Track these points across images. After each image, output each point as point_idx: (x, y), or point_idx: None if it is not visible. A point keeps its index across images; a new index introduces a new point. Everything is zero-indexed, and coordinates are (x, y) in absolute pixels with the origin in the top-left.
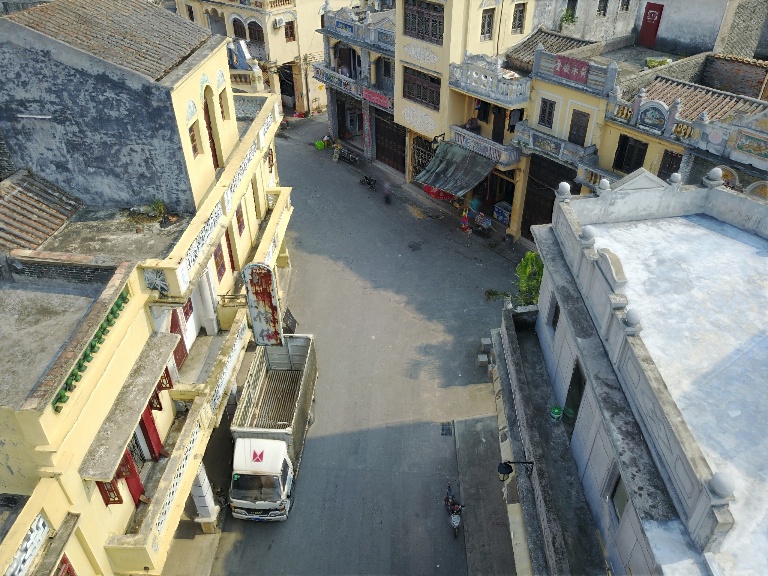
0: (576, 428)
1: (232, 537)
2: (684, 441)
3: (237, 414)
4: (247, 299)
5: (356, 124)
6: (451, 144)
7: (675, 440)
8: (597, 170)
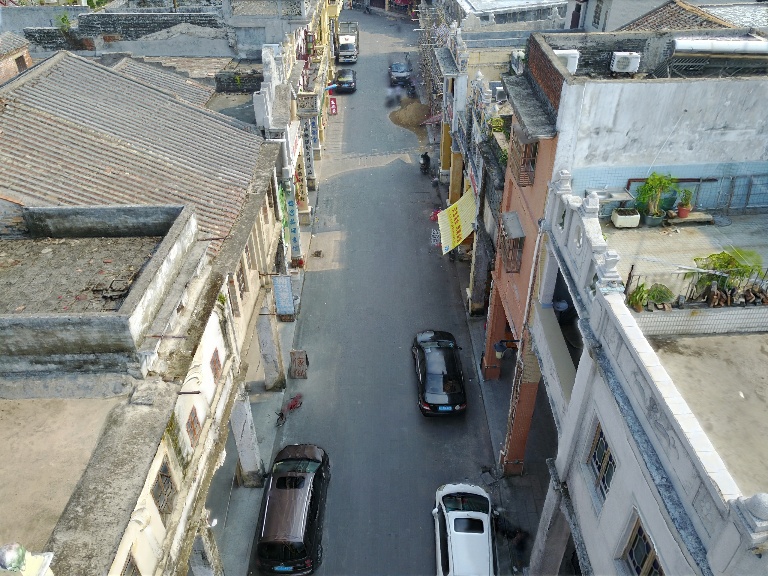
0: None
1: None
2: None
3: None
4: None
5: None
6: None
7: None
8: None
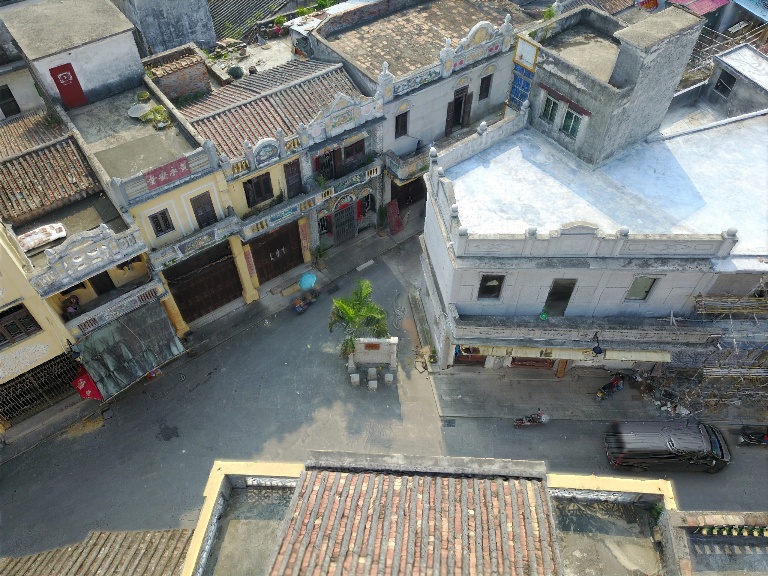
0: (571, 305)
1: None
2: (700, 238)
3: None
4: None
5: None
6: (85, 338)
7: (692, 242)
8: (263, 218)
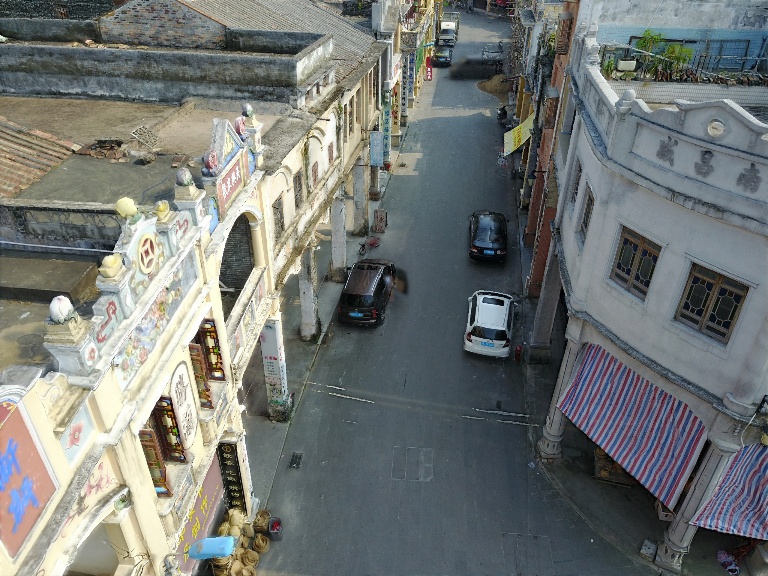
0: None
1: None
2: None
3: None
4: None
5: None
6: None
7: None
8: None
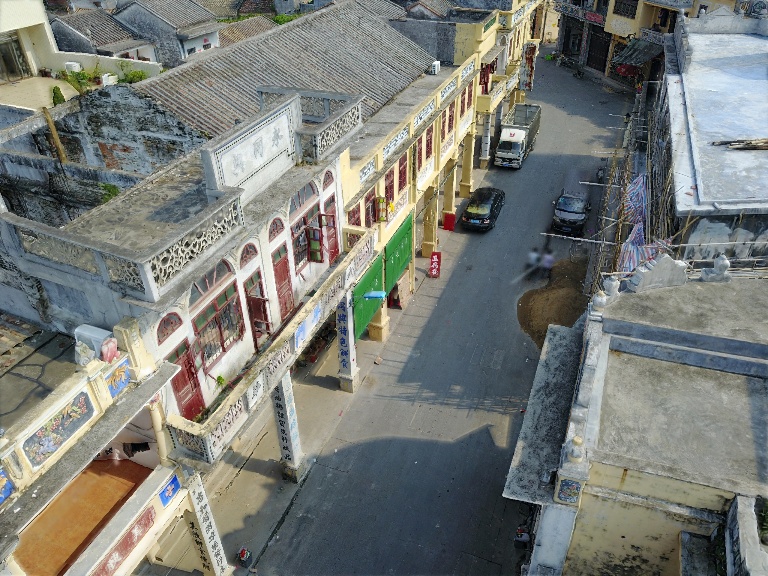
0: None
1: (493, 172)
2: None
3: (503, 122)
4: (521, 62)
5: (576, 46)
6: (639, 40)
7: None
8: None
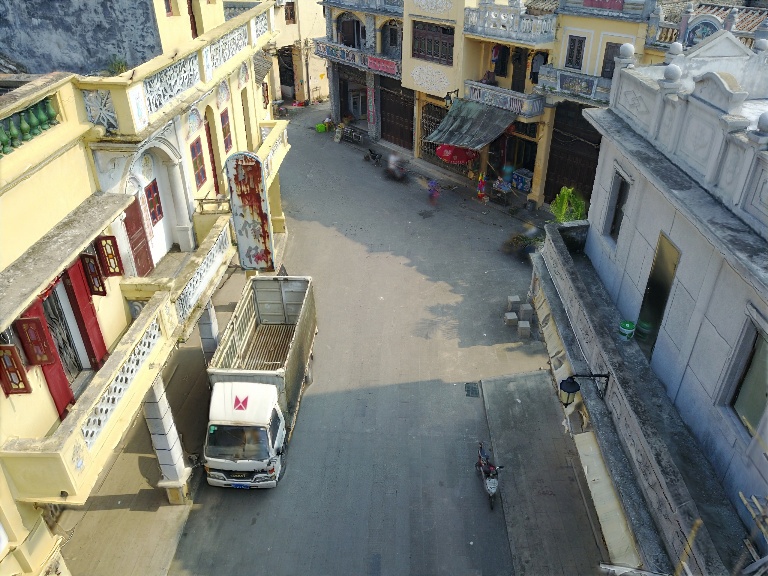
0: (661, 335)
1: (206, 509)
2: None
3: (217, 356)
4: (231, 204)
5: (359, 107)
6: (466, 101)
7: None
8: None
